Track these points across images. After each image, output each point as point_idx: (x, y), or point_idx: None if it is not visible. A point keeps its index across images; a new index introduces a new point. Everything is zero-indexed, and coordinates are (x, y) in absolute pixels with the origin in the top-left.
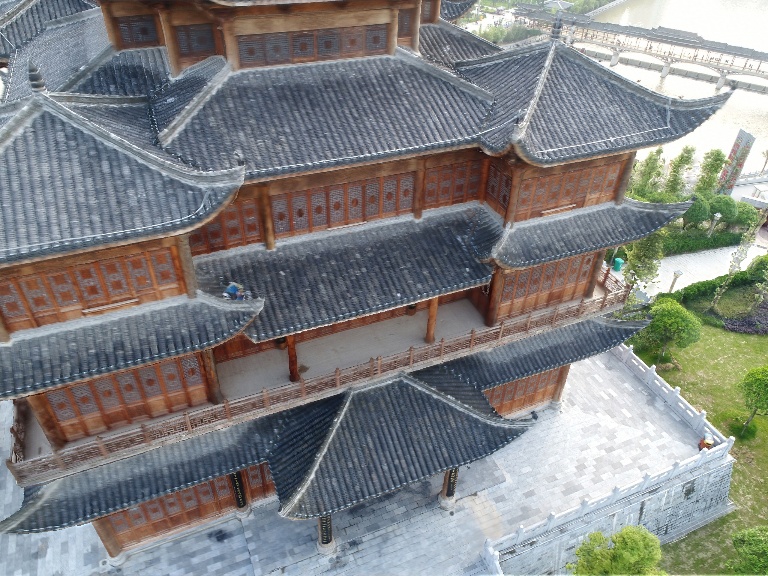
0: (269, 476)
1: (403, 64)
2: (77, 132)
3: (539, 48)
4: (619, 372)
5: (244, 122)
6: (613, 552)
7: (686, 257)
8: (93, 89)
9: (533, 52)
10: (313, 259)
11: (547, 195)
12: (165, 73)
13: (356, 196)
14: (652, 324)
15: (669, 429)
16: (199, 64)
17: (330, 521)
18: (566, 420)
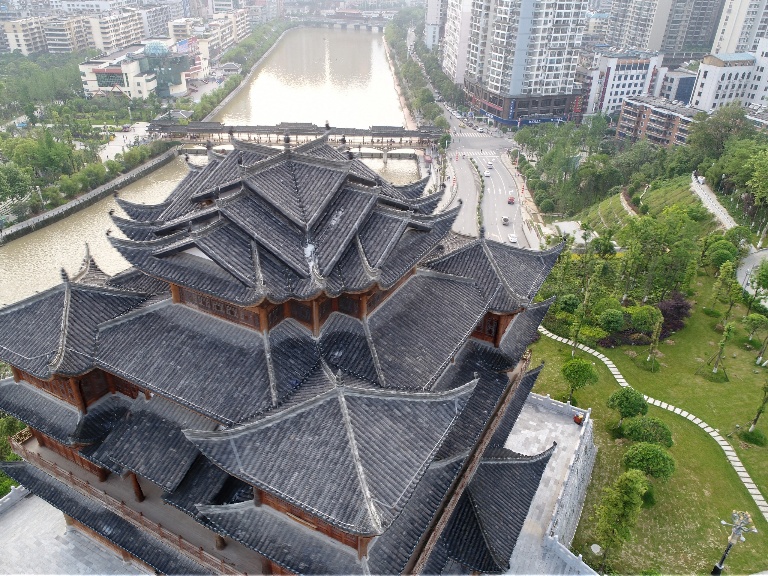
0: None
1: (423, 277)
2: (370, 400)
3: (474, 244)
4: None
5: (401, 350)
6: (624, 491)
7: None
8: (283, 367)
9: (471, 246)
10: None
11: None
12: (307, 336)
13: None
14: None
15: (557, 421)
16: (326, 322)
17: None
18: (511, 445)
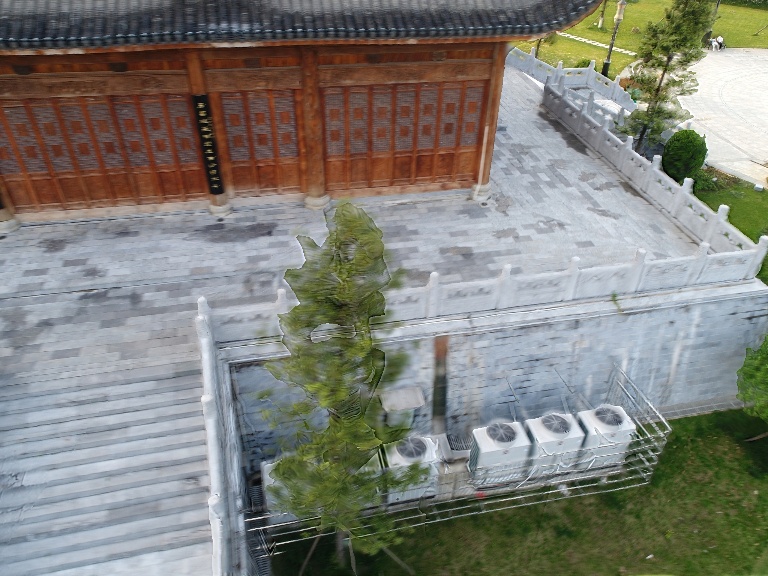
0: None
1: None
2: None
3: None
4: None
5: None
6: None
7: None
8: None
9: None
10: None
11: None
12: None
13: None
14: None
15: None
16: None
17: None
18: None
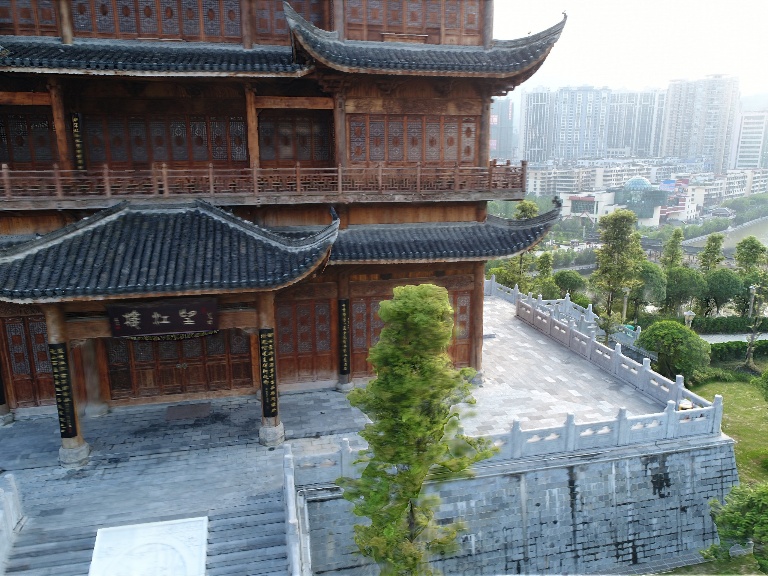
0: (41, 365)
1: None
2: None
3: None
4: (579, 365)
5: None
6: None
7: (721, 336)
8: None
9: None
10: (106, 51)
11: (385, 12)
12: None
13: (170, 5)
14: (642, 342)
15: (634, 408)
16: None
17: (69, 389)
18: (484, 392)
